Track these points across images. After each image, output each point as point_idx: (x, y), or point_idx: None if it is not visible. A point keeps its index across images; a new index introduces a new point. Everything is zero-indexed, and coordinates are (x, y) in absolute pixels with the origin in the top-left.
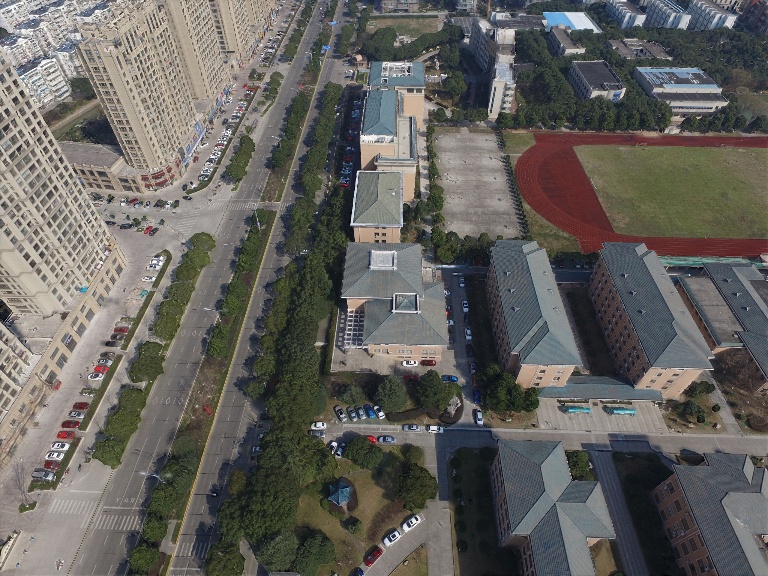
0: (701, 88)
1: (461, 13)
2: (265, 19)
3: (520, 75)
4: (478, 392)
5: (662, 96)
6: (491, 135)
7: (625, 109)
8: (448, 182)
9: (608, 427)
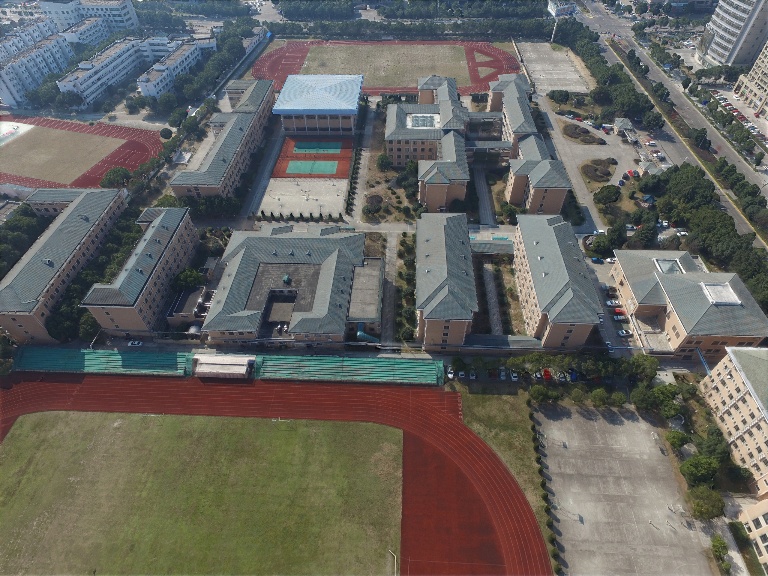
0: None
1: None
2: None
3: None
4: None
5: None
6: None
7: None
8: None
9: (479, 235)
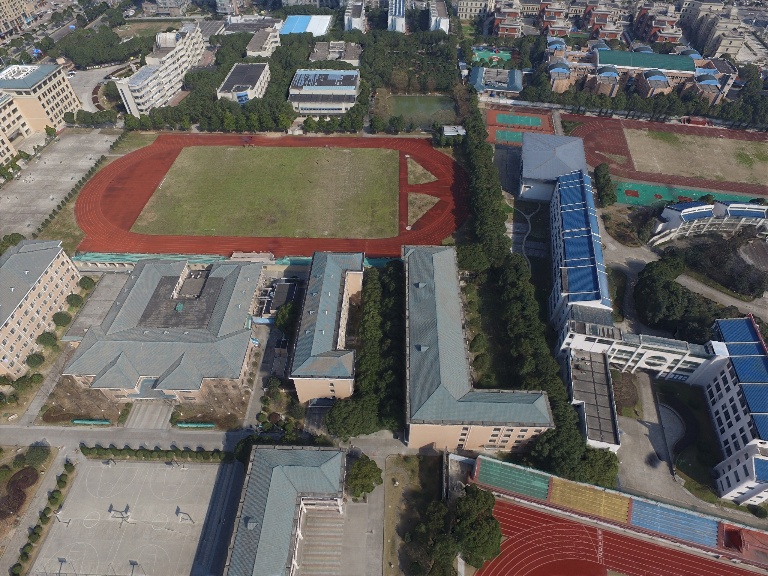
0: (335, 90)
1: (216, 17)
2: (6, 23)
3: (185, 77)
4: None
5: (296, 98)
6: (116, 136)
7: (247, 110)
8: (22, 182)
9: None
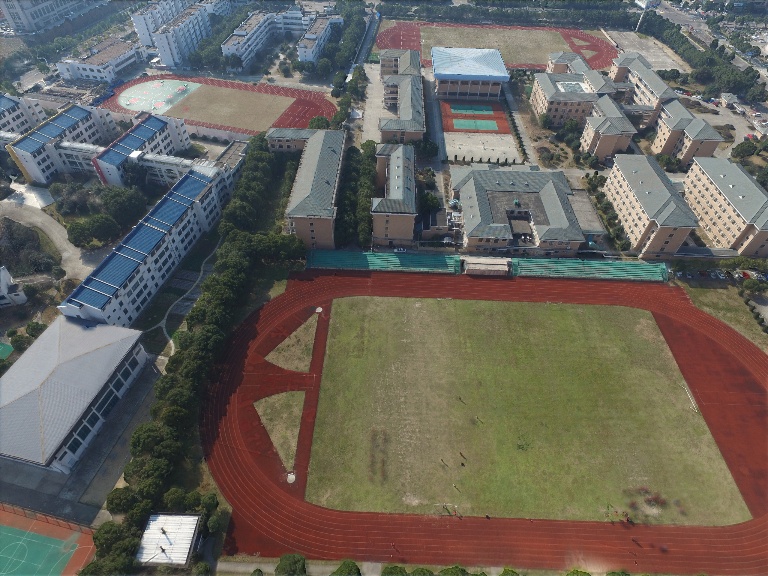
0: None
1: None
2: None
3: None
4: None
5: None
6: None
7: None
8: None
9: None
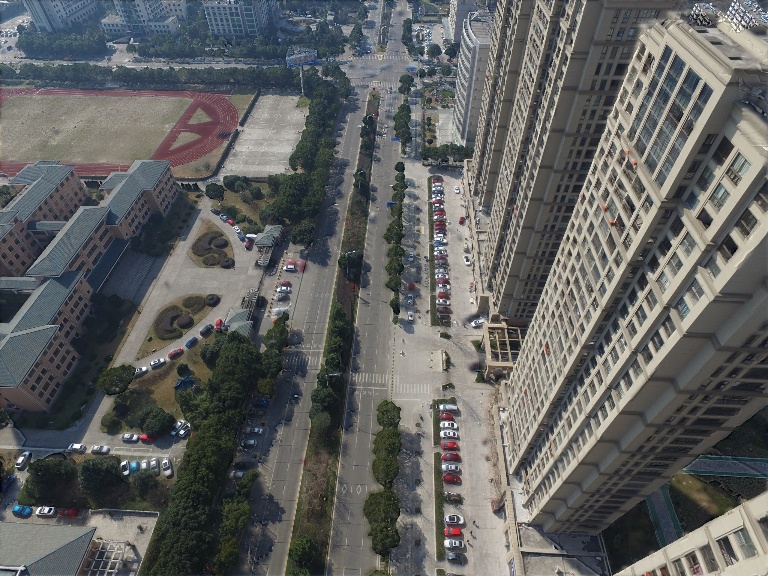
0: None
1: None
2: None
3: None
4: (2, 488)
5: None
6: None
7: None
8: None
9: None
